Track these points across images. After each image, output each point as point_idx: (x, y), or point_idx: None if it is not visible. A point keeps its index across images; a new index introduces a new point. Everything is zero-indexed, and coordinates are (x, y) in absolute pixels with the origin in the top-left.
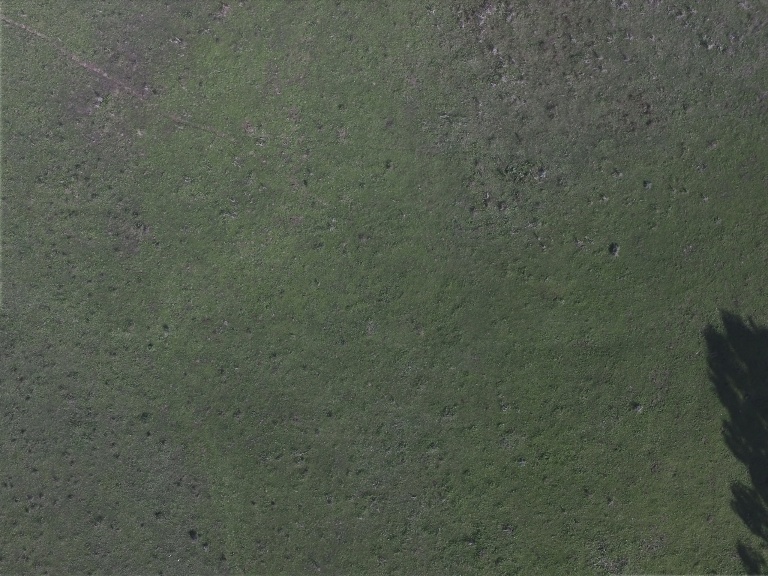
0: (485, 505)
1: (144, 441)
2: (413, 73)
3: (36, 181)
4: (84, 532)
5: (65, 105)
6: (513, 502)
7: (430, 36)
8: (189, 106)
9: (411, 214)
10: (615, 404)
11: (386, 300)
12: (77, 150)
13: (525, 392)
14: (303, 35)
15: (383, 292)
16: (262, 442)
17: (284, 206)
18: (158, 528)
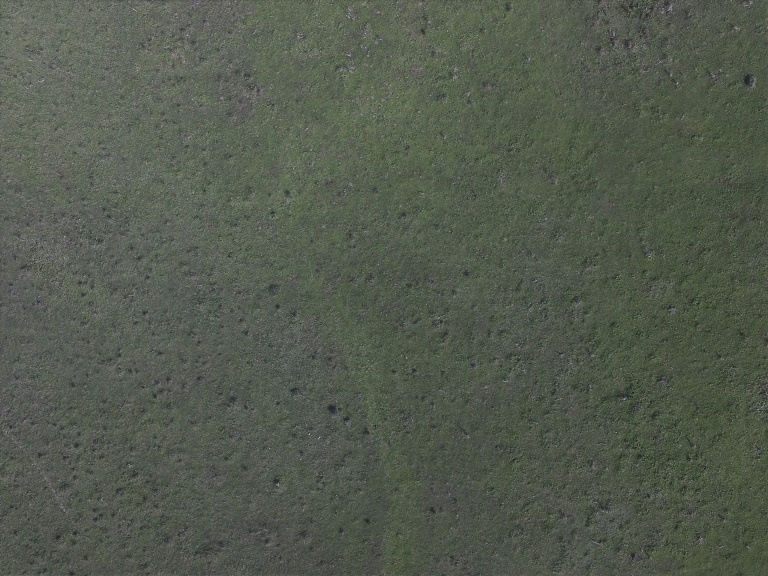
0: (636, 357)
1: (273, 315)
2: None
3: (140, 48)
4: (216, 415)
5: None
6: (665, 352)
7: None
8: None
9: (535, 58)
10: (766, 240)
11: (516, 150)
12: (181, 13)
13: (669, 236)
14: None
15: (513, 141)
16: (398, 307)
17: (402, 58)
18: (295, 405)
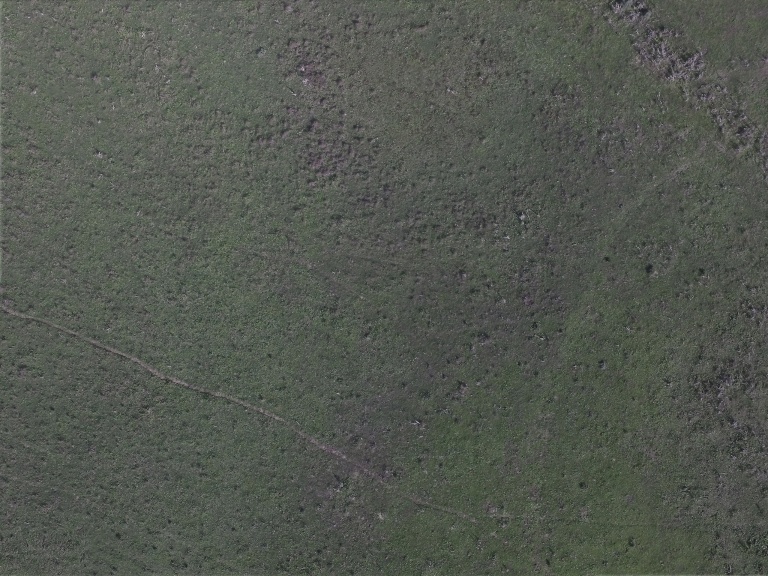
0: None
1: None
2: (652, 447)
3: (278, 568)
4: None
5: (305, 489)
6: None
7: (668, 408)
8: (429, 488)
9: None
10: None
11: None
12: (318, 535)
13: None
14: (541, 412)
15: None
16: None
17: None
18: None
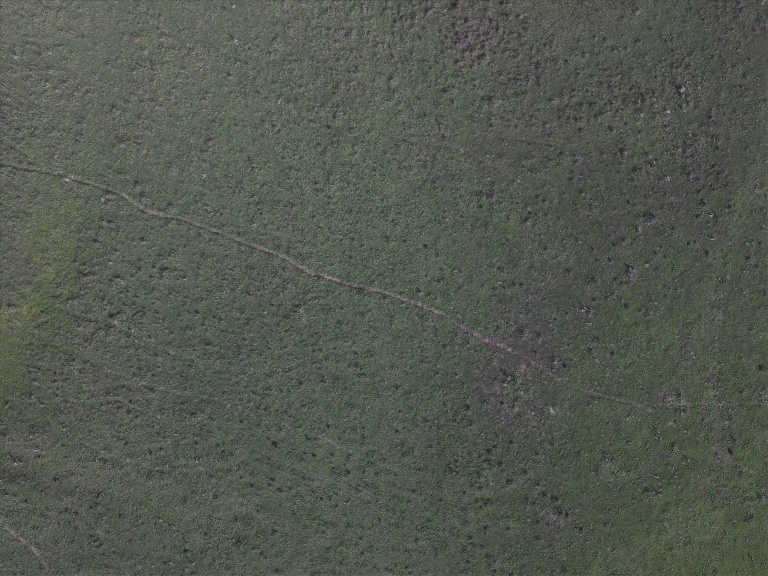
0: None
1: None
2: None
3: (446, 470)
4: None
5: (470, 385)
6: None
7: None
8: (601, 378)
9: None
10: None
11: None
12: (487, 433)
13: None
14: (714, 293)
15: None
16: None
17: (709, 477)
18: None
